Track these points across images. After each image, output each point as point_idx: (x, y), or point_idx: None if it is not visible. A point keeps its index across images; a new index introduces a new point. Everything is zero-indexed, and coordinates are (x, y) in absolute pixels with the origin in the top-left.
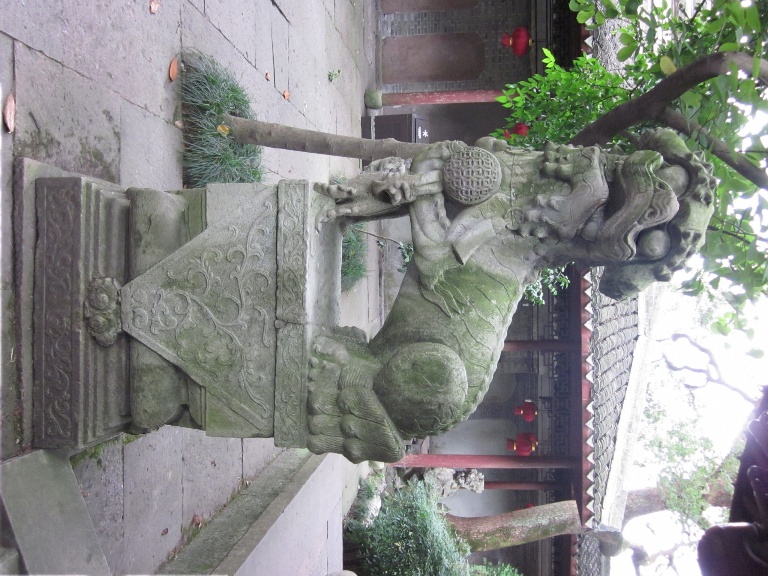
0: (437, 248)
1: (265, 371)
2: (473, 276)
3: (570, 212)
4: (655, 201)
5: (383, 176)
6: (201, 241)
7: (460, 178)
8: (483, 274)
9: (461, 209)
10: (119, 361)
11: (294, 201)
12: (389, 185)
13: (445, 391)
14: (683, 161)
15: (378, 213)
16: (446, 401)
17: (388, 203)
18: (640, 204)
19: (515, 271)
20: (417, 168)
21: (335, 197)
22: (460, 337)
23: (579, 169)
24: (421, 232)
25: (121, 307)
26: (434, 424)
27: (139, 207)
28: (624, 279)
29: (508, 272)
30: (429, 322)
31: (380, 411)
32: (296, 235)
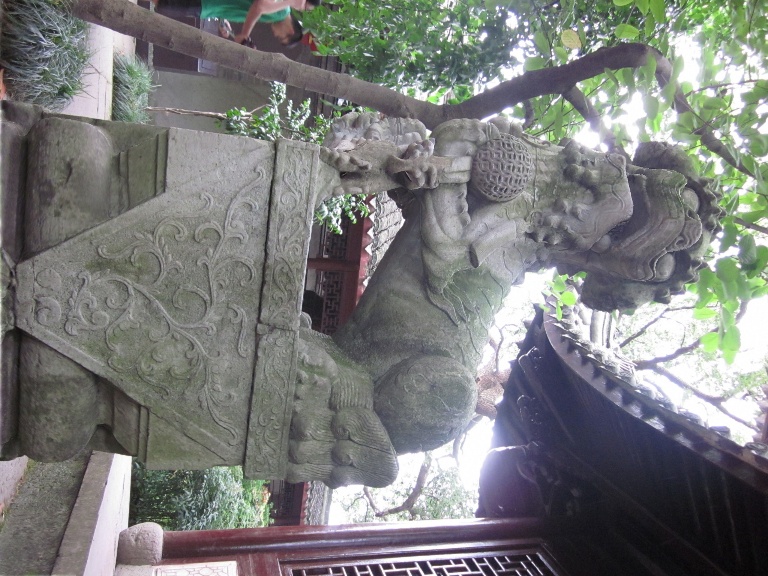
0: (454, 247)
1: (237, 387)
2: (481, 279)
3: (595, 224)
4: (687, 230)
5: (397, 150)
6: (156, 209)
7: (499, 172)
8: (490, 277)
9: (483, 204)
10: (2, 369)
11: (297, 171)
12: (415, 166)
13: (461, 415)
14: (696, 186)
15: None
16: (459, 425)
17: (398, 184)
18: (672, 231)
19: (514, 274)
20: (443, 148)
21: (342, 169)
22: (464, 348)
23: (608, 179)
24: (438, 226)
25: (16, 294)
26: (437, 447)
27: (52, 145)
28: (627, 297)
29: (509, 275)
30: (435, 331)
31: (386, 438)
32: (296, 217)
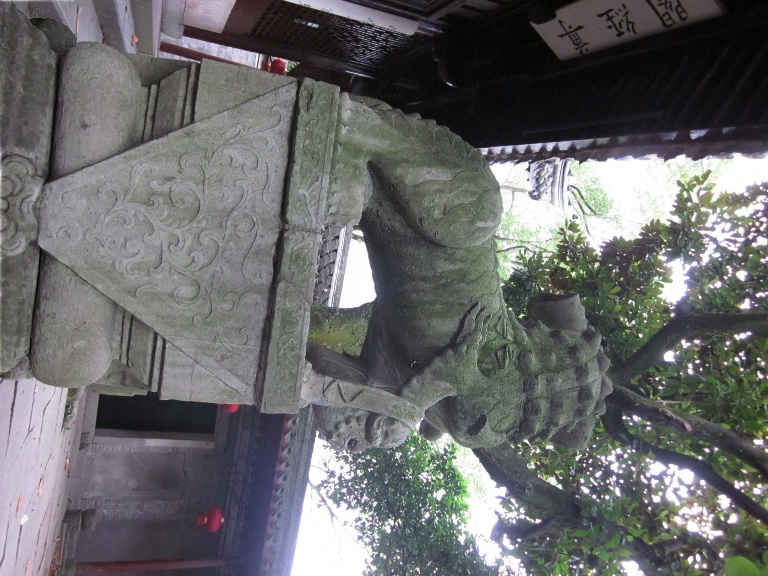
0: None
1: None
2: None
3: None
4: None
5: None
6: None
7: None
8: None
9: None
10: None
11: None
12: None
13: None
14: None
15: (342, 372)
16: None
17: None
18: None
19: None
20: None
21: None
22: None
23: None
24: None
25: None
26: None
27: None
28: None
29: None
30: None
31: None
32: None
